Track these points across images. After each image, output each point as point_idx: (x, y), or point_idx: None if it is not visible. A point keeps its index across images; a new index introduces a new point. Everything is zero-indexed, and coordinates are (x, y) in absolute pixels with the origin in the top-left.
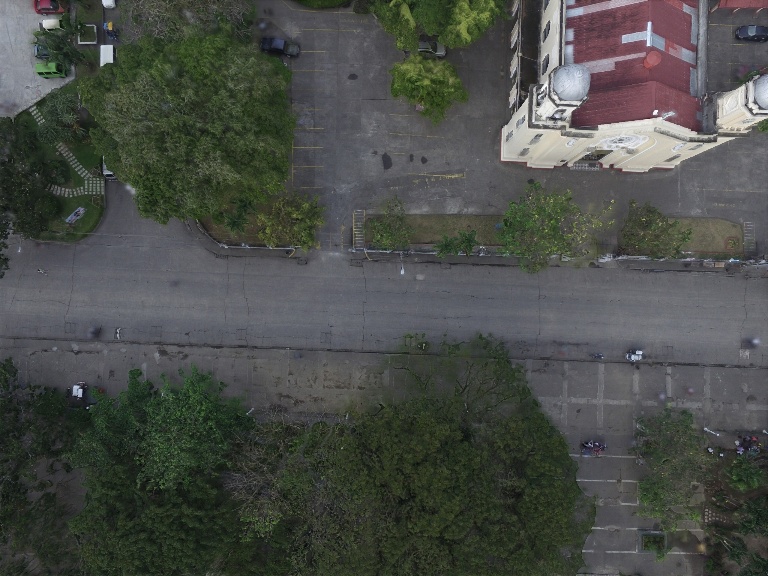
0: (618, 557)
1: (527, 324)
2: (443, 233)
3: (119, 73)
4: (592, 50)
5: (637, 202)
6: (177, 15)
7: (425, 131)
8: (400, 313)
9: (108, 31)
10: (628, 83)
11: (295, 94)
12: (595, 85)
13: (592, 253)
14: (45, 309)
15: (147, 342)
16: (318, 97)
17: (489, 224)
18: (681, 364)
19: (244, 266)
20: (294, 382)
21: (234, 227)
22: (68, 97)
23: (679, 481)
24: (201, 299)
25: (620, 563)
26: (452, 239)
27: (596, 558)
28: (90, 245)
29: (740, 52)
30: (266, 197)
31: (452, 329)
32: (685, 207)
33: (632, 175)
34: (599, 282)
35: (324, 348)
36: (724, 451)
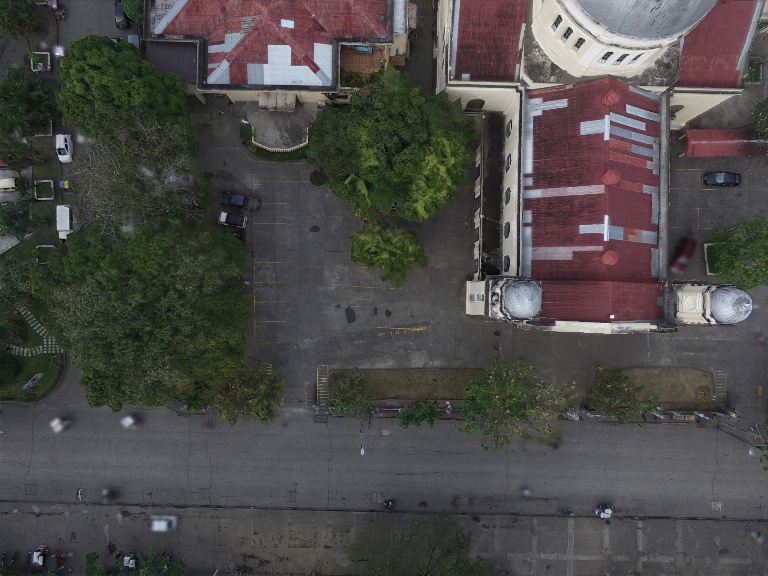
0: None
1: (495, 479)
2: (408, 387)
3: (67, 268)
4: (550, 236)
5: (605, 352)
6: (123, 217)
7: (389, 283)
8: (366, 470)
9: (64, 188)
10: (586, 276)
11: (256, 247)
12: (553, 272)
13: None
14: (5, 471)
15: (109, 503)
16: (280, 250)
17: (455, 377)
18: (652, 517)
19: (207, 424)
20: (259, 542)
21: (190, 407)
22: (22, 265)
23: None
24: (163, 458)
25: None
26: (414, 412)
27: None
28: (50, 404)
29: (709, 197)
30: (222, 378)
31: (419, 485)
32: (654, 357)
33: None
34: (568, 435)
35: (289, 507)
36: None
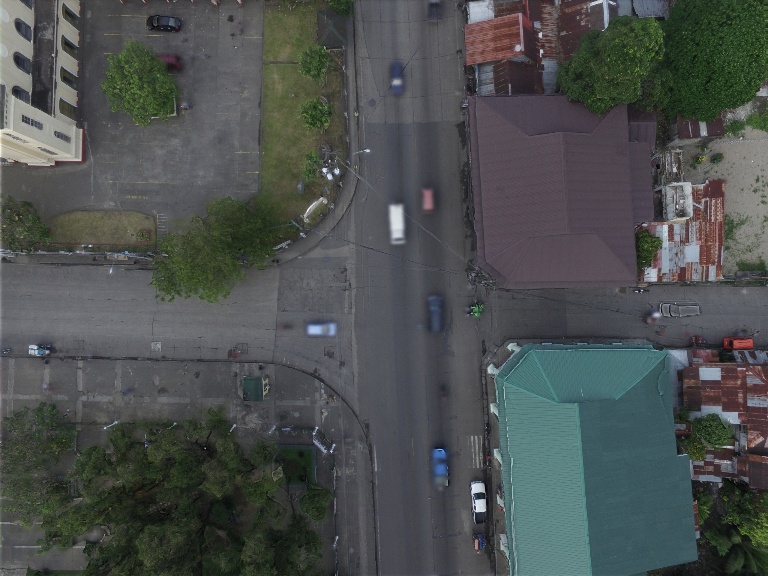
0: (26, 552)
1: None
2: None
3: None
4: None
5: (49, 196)
6: None
7: None
8: None
9: None
10: None
11: None
12: None
13: (3, 248)
14: None
15: None
16: None
17: None
18: (94, 358)
19: None
20: None
21: None
22: None
23: (12, 475)
24: None
25: (29, 558)
26: None
27: (5, 553)
28: None
29: (154, 43)
30: None
31: None
32: (98, 200)
33: (44, 169)
34: (10, 277)
35: None
36: (133, 444)
